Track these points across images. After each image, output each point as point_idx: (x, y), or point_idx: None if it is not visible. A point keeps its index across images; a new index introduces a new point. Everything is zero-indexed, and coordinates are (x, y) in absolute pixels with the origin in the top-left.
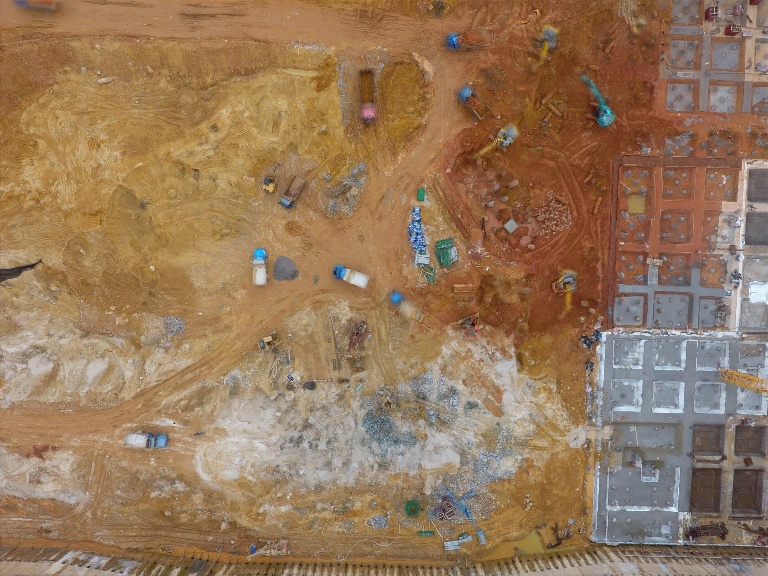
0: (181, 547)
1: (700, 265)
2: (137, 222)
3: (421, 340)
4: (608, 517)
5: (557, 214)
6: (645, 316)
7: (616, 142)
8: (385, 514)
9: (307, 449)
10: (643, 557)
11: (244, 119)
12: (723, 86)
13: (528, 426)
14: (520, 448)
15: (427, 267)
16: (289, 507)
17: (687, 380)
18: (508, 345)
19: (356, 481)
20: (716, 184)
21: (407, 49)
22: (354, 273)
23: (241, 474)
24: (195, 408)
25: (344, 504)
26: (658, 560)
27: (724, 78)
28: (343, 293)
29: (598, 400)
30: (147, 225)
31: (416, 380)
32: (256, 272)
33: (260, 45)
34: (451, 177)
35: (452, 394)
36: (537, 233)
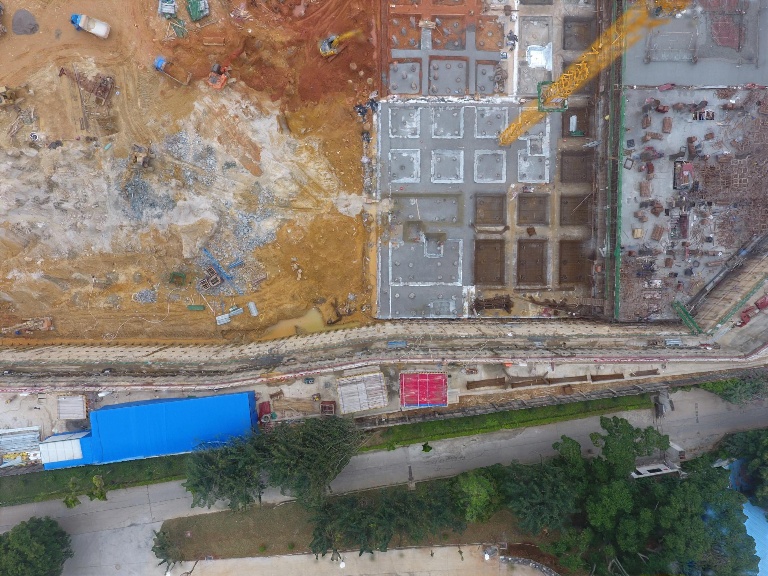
0: None
1: (474, 27)
2: None
3: (172, 96)
4: (391, 293)
5: None
6: (420, 83)
7: None
8: (151, 287)
9: (53, 209)
10: (418, 323)
11: None
12: None
13: (289, 186)
14: (282, 209)
15: (174, 18)
16: (41, 273)
17: (466, 148)
18: (270, 106)
19: (112, 247)
20: None
21: None
22: (94, 22)
23: None
24: None
25: (106, 276)
26: (432, 324)
27: None
28: (88, 48)
29: (377, 173)
30: None
31: (167, 137)
32: None
33: None
34: None
35: (209, 154)
36: None
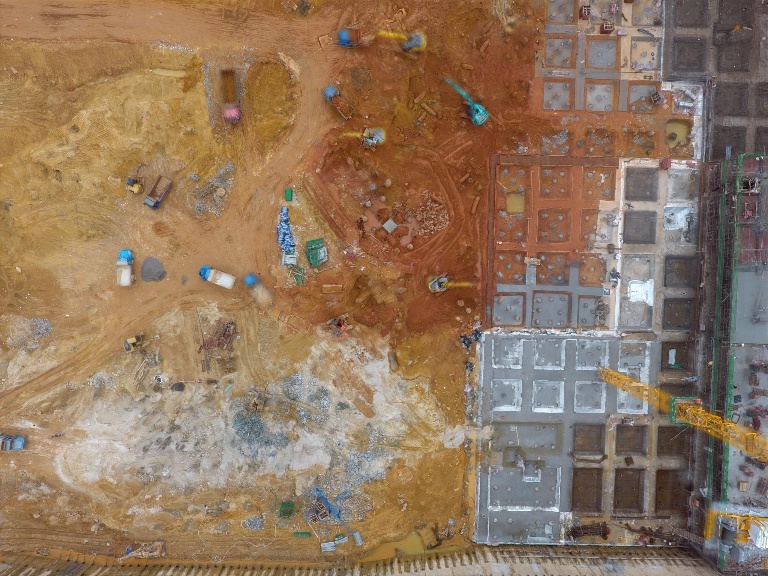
0: (57, 550)
1: (578, 264)
2: (4, 224)
3: (290, 341)
4: (489, 517)
5: (434, 214)
6: (524, 315)
7: (492, 141)
8: (260, 515)
9: (174, 451)
10: (519, 557)
11: (104, 120)
12: (600, 85)
13: (400, 426)
14: (392, 448)
15: (295, 267)
16: (158, 509)
17: (567, 379)
18: (382, 345)
19: (227, 482)
20: (594, 183)
21: (273, 49)
22: (220, 274)
23: (102, 476)
24: (54, 410)
25: (218, 506)
26: (533, 560)
27: (600, 77)
28: (212, 294)
29: (479, 400)
30: (10, 226)
31: (285, 381)
32: (121, 273)
33: (123, 45)
34: (321, 177)
35: (323, 395)
36: (416, 233)
